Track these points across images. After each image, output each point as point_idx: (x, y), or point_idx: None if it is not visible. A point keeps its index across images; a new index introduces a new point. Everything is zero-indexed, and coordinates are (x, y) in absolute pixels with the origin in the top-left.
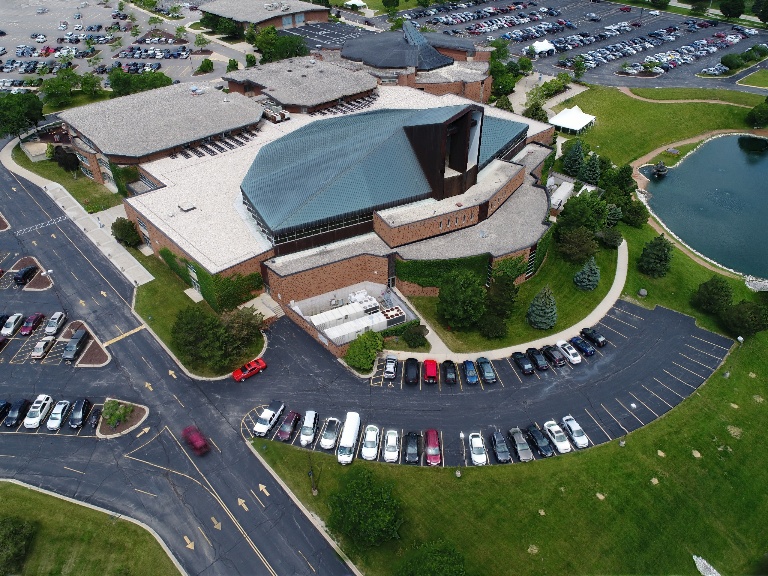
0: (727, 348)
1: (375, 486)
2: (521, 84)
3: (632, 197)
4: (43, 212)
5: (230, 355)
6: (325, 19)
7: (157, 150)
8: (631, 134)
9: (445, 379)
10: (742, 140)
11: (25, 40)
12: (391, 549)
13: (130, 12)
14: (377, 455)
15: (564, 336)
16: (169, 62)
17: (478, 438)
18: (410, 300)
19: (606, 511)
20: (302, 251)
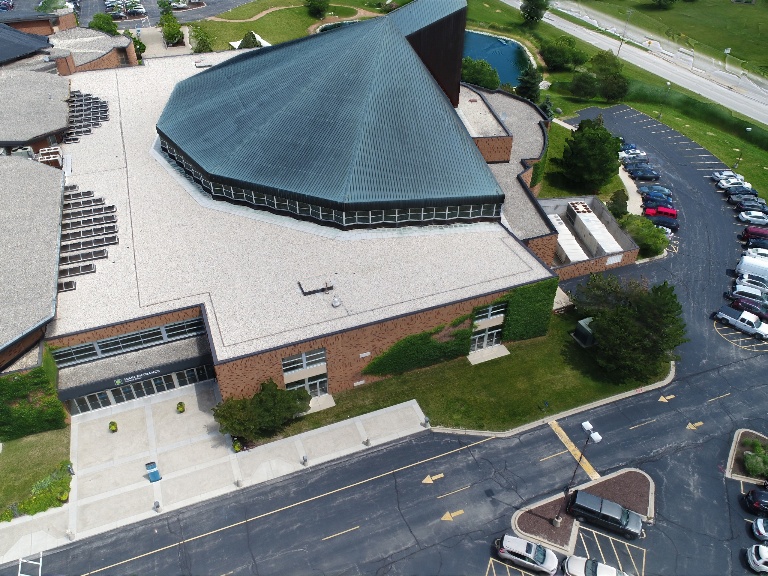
0: (630, 108)
1: None
2: None
3: None
4: None
5: None
6: None
7: (53, 286)
8: None
9: None
10: None
11: None
12: None
13: None
14: None
15: None
16: None
17: (752, 212)
18: None
19: None
20: None
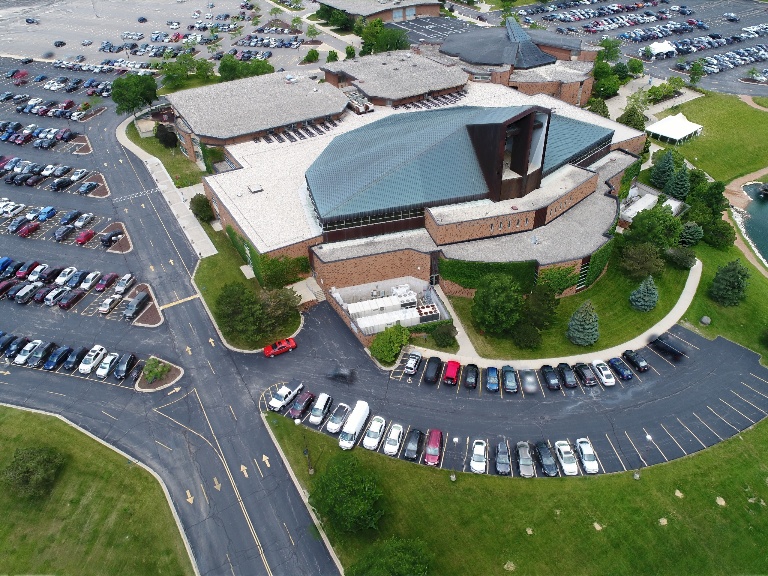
0: None
1: (358, 474)
2: (628, 87)
3: (726, 216)
4: (140, 183)
5: (264, 331)
6: (436, 13)
7: (242, 134)
8: (742, 147)
9: (464, 382)
10: None
11: (162, 27)
12: (369, 538)
13: (257, 3)
14: (378, 446)
15: (603, 355)
16: (280, 51)
17: (481, 445)
18: (450, 299)
19: (599, 543)
20: (350, 240)
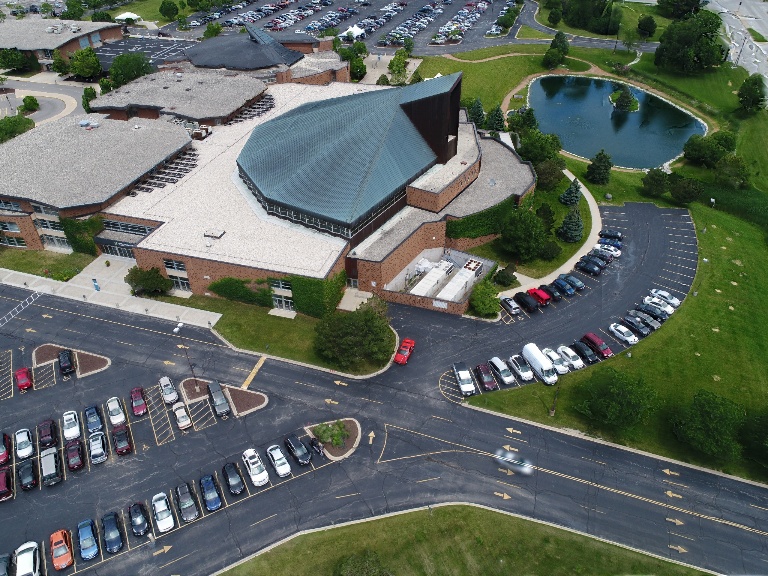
0: (688, 215)
1: None
2: None
3: None
4: None
5: None
6: (120, 36)
7: (118, 190)
8: (483, 90)
9: (553, 298)
10: (543, 81)
11: None
12: (638, 423)
13: None
14: None
15: (592, 241)
16: None
17: (620, 326)
18: None
19: (728, 336)
20: (367, 238)
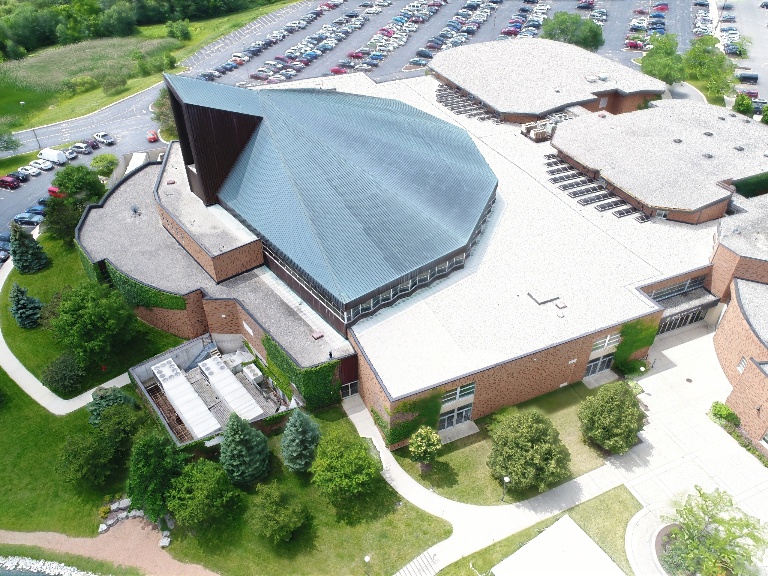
0: None
1: None
2: None
3: None
4: None
5: None
6: None
7: (438, 71)
8: None
9: None
10: None
11: None
12: None
13: None
14: None
15: (2, 275)
16: None
17: None
18: None
19: None
20: None
